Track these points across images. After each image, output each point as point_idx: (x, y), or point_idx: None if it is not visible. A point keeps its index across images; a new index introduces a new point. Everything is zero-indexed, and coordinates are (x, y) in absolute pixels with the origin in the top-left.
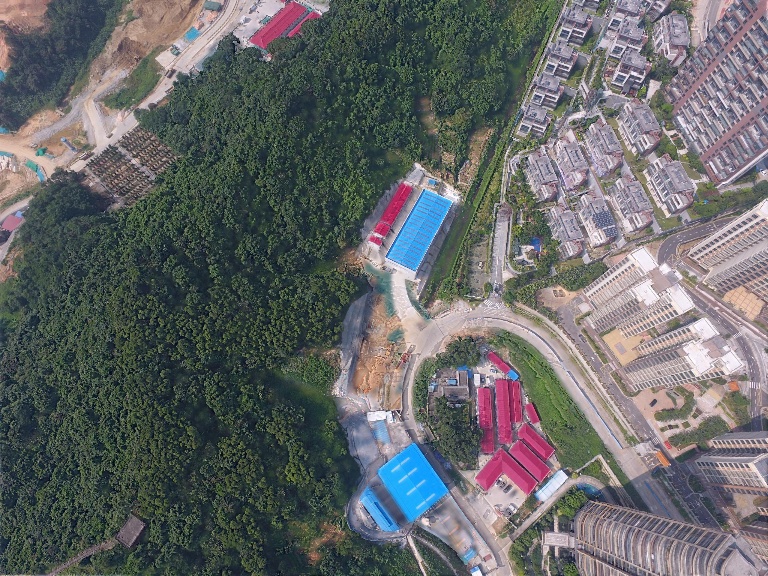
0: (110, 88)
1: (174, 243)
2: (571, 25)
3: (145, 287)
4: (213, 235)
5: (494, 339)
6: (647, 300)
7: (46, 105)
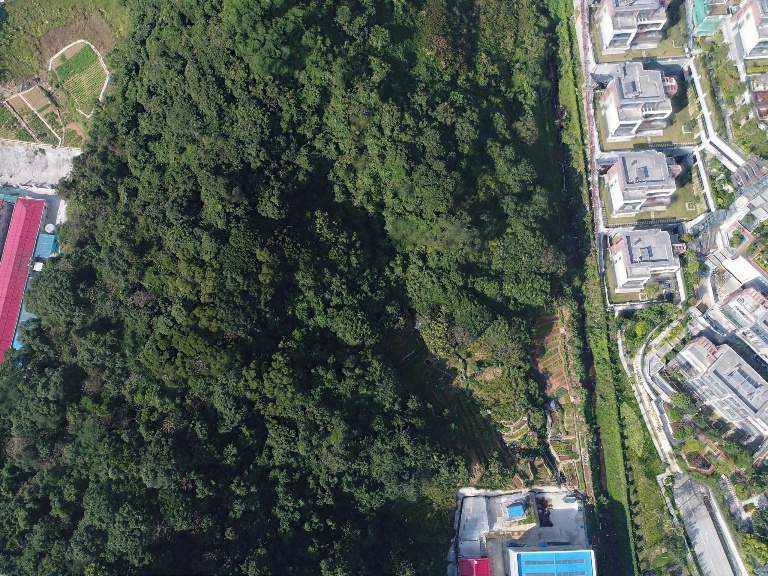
0: None
1: None
2: (628, 18)
3: None
4: None
5: None
6: None
7: None
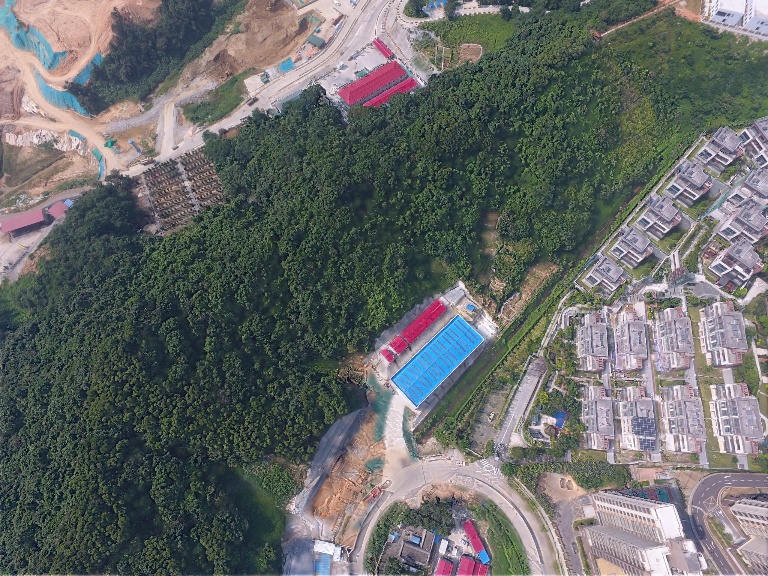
0: (194, 96)
1: (180, 304)
2: (684, 183)
3: (134, 346)
4: (220, 308)
5: (477, 507)
6: (655, 572)
7: (131, 96)
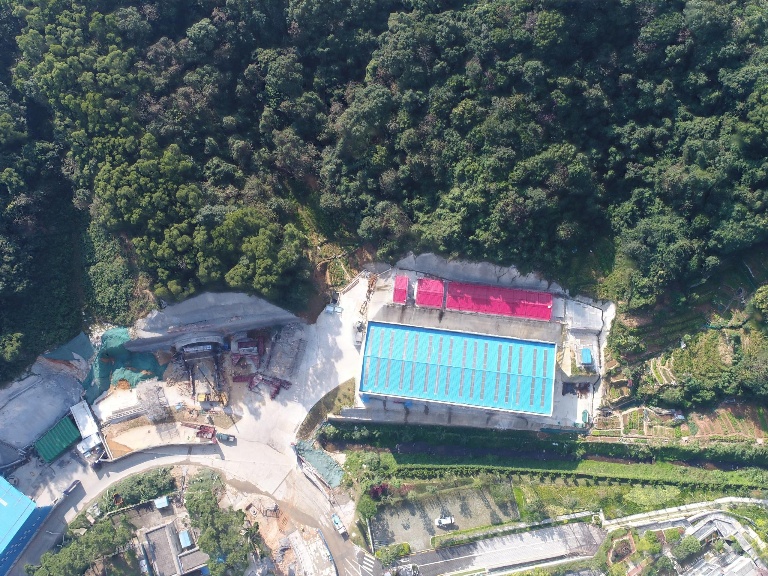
0: None
1: None
2: None
3: None
4: None
5: None
6: None
7: None
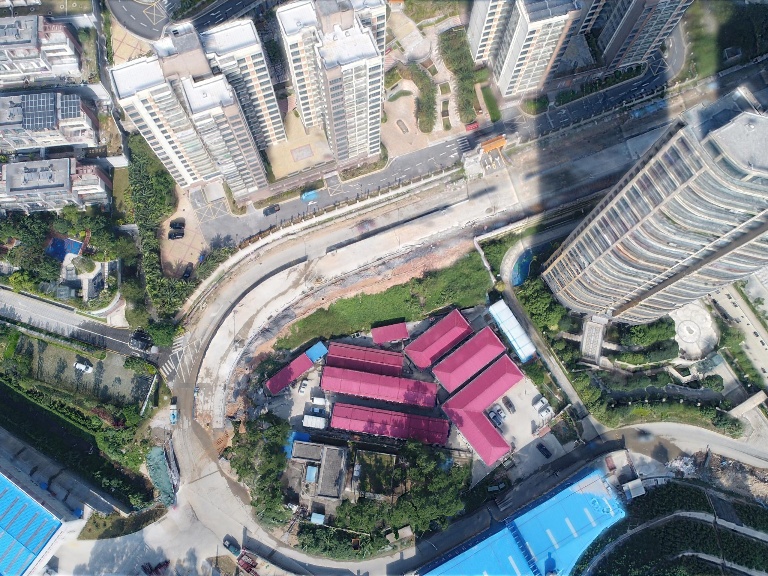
0: None
1: None
2: None
3: None
4: None
5: (243, 373)
6: (222, 99)
7: None
